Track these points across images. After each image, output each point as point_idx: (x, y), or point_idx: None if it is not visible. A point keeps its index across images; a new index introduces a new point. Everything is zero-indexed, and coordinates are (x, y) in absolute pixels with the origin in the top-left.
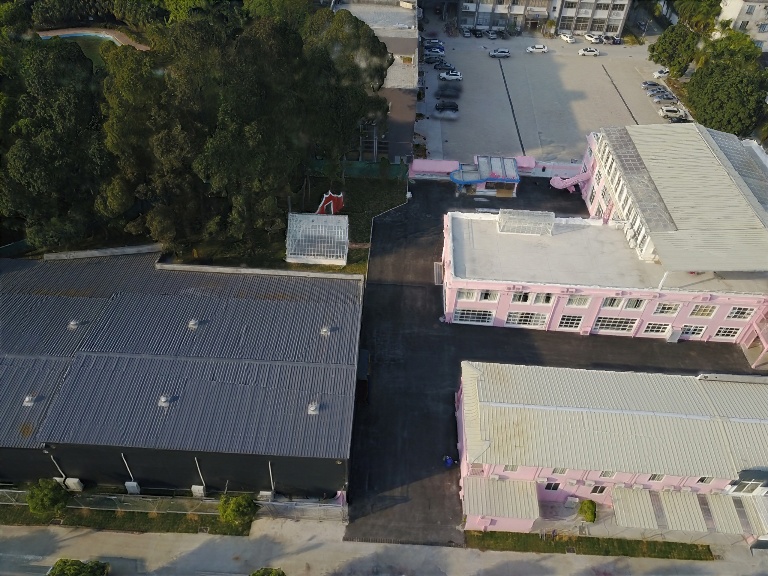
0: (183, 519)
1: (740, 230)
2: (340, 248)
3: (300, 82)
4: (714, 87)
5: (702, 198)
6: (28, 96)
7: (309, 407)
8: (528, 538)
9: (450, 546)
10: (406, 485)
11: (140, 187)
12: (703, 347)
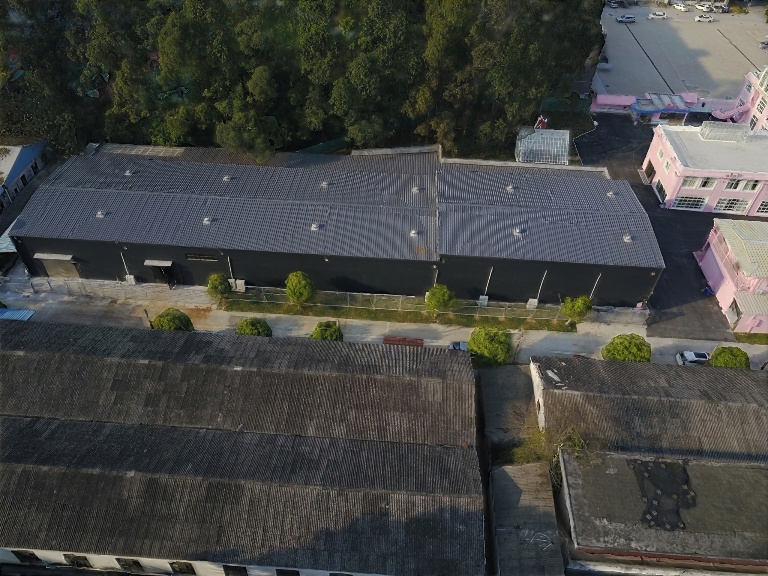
0: (525, 322)
1: None
2: (564, 156)
3: (561, 14)
4: None
5: None
6: (369, 20)
7: (624, 237)
8: None
9: (727, 341)
10: (680, 306)
11: (446, 92)
12: None
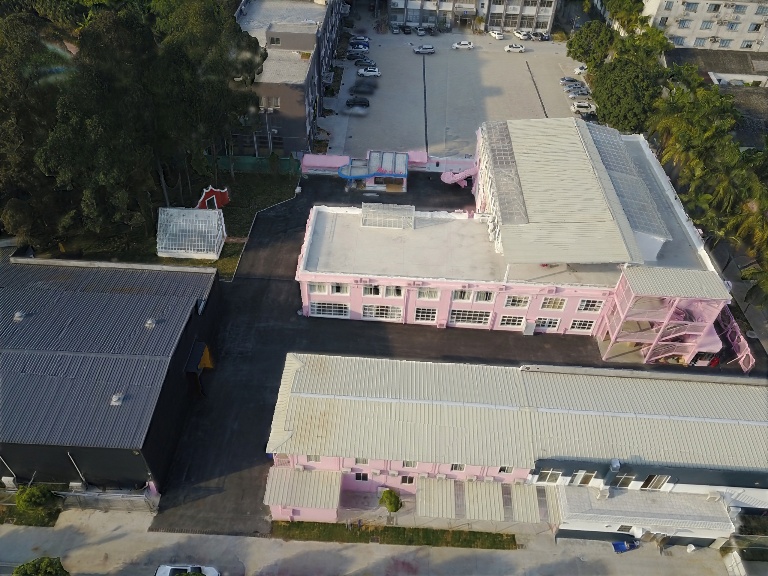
0: None
1: (589, 223)
2: (211, 242)
3: (150, 76)
4: (613, 82)
5: (561, 191)
6: None
7: (113, 398)
8: (334, 528)
9: (254, 536)
10: (224, 476)
11: None
12: (559, 340)
